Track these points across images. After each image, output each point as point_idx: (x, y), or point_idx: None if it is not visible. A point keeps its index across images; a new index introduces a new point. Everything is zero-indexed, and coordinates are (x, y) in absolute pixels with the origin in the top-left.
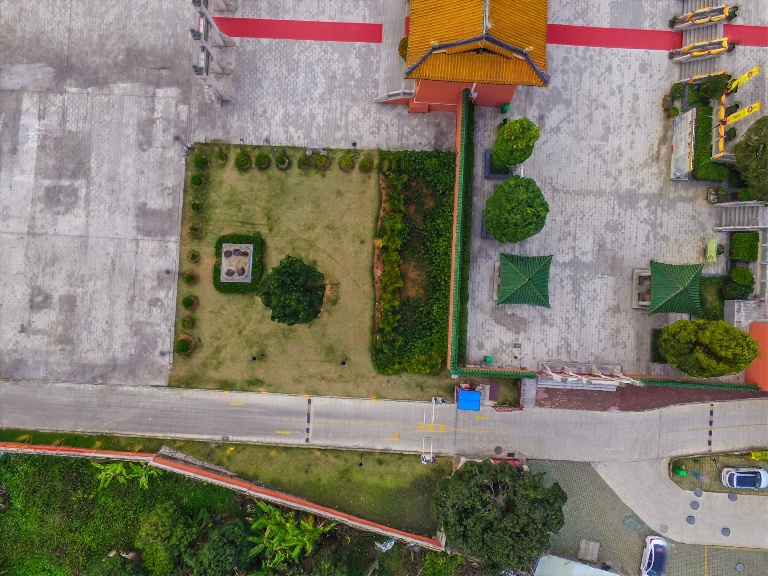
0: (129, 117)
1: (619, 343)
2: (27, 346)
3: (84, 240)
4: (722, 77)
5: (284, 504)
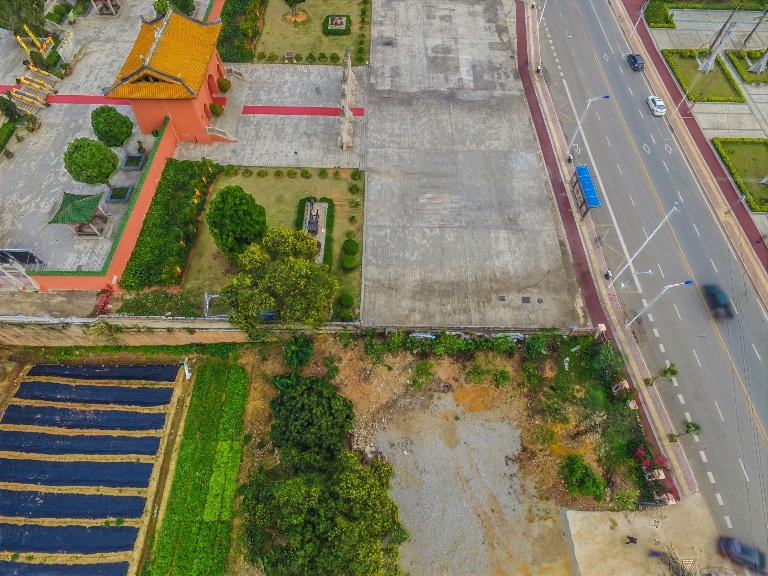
0: (406, 78)
1: None
2: (450, 5)
3: (426, 36)
4: (35, 53)
5: None
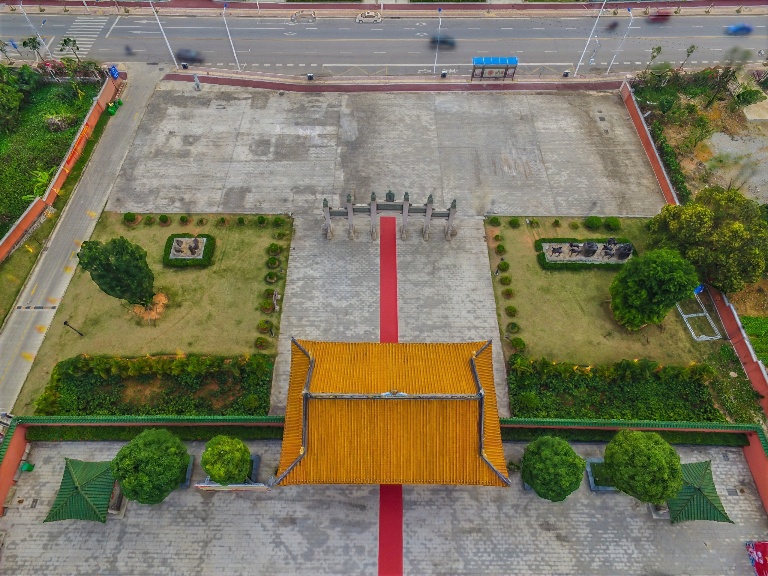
0: (318, 180)
1: None
2: (159, 135)
3: (229, 160)
4: None
5: None
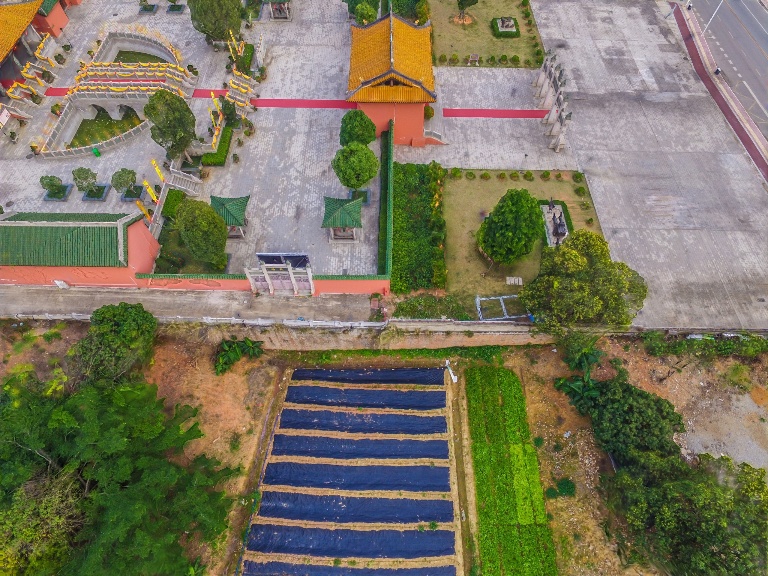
0: (590, 80)
1: (301, 0)
2: (606, 7)
3: (594, 38)
4: None
5: None
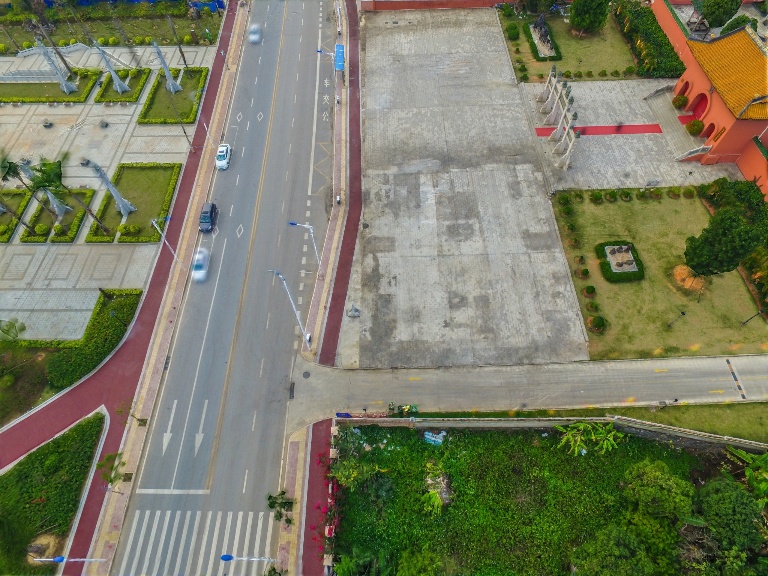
0: (500, 181)
1: None
2: (453, 338)
3: (485, 257)
4: None
5: (767, 447)
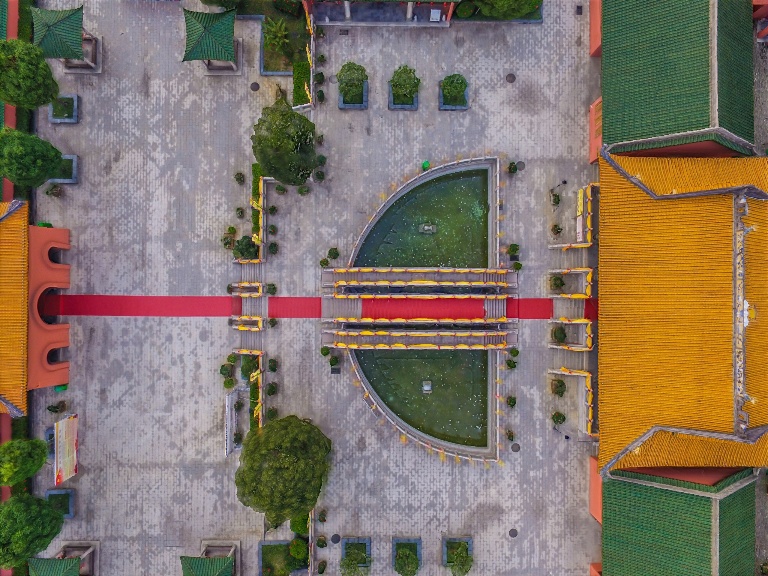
0: None
1: None
2: None
3: None
4: None
5: None
